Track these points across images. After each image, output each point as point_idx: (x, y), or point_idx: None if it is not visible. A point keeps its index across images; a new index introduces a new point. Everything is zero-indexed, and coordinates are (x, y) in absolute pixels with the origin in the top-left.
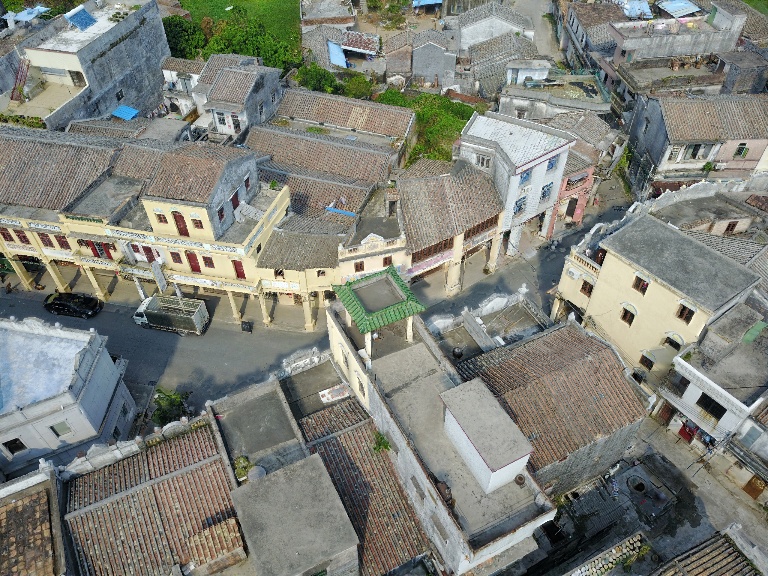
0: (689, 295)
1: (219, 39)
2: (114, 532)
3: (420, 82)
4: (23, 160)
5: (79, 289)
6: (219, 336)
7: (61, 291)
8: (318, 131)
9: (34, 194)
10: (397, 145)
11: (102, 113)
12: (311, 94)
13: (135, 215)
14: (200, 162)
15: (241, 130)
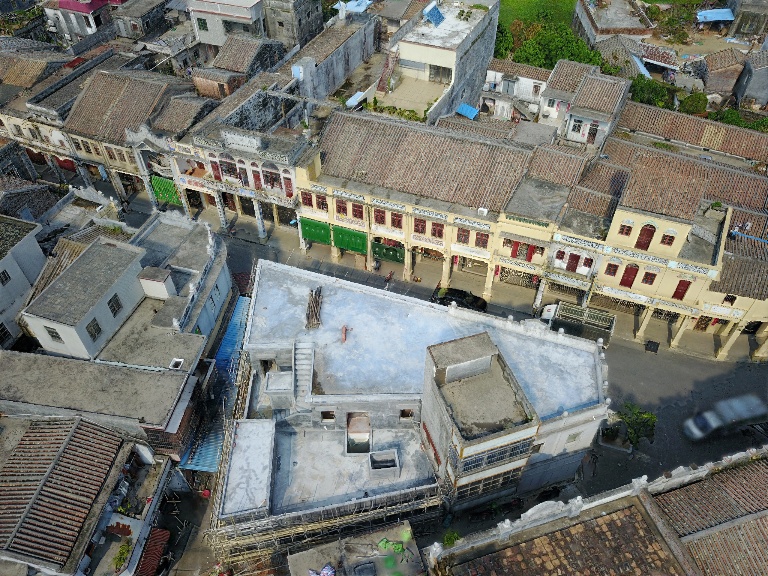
0: None
1: (535, 43)
2: (731, 564)
3: (750, 103)
4: (434, 154)
5: (456, 286)
6: (622, 353)
7: (443, 286)
8: (667, 147)
9: (448, 189)
10: (763, 170)
11: (452, 110)
12: (656, 108)
13: (571, 222)
14: (677, 177)
15: (597, 140)
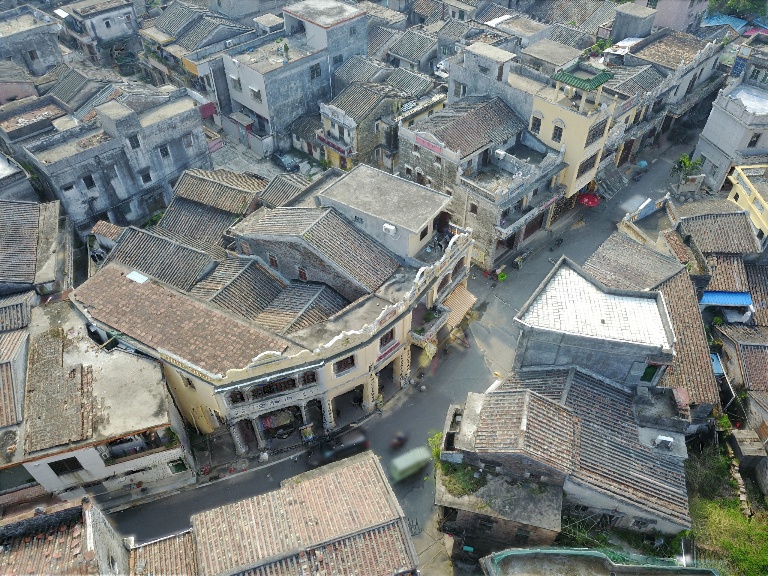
0: (378, 173)
1: None
2: None
3: None
4: None
5: None
6: None
7: None
8: None
9: None
10: None
11: None
12: None
13: None
14: None
15: None
